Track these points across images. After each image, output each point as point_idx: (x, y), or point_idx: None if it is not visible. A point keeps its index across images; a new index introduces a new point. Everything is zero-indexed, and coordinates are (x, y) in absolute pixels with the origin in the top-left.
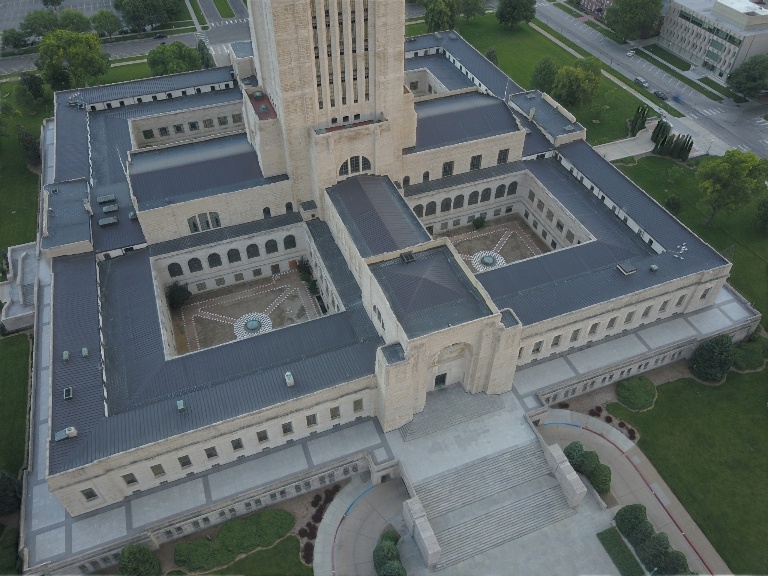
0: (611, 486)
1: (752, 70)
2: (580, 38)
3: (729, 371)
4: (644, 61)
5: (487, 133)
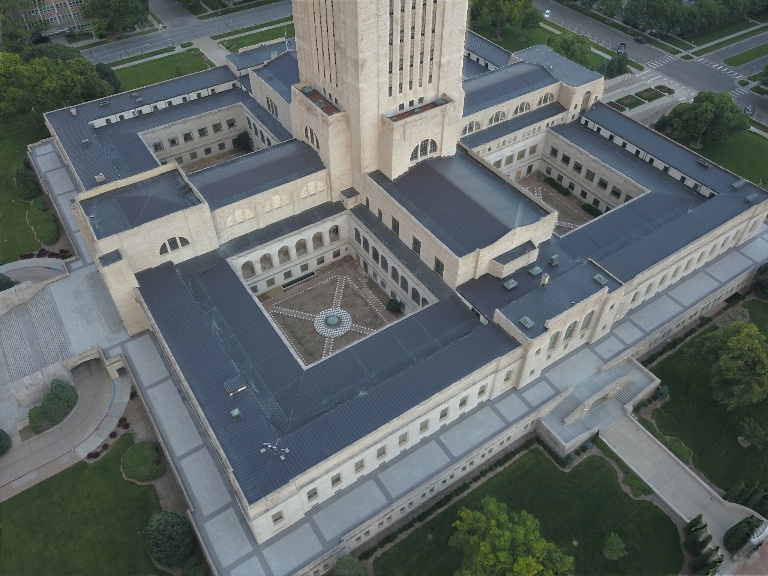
0: (42, 436)
1: None
2: None
3: (173, 575)
4: None
5: (446, 231)
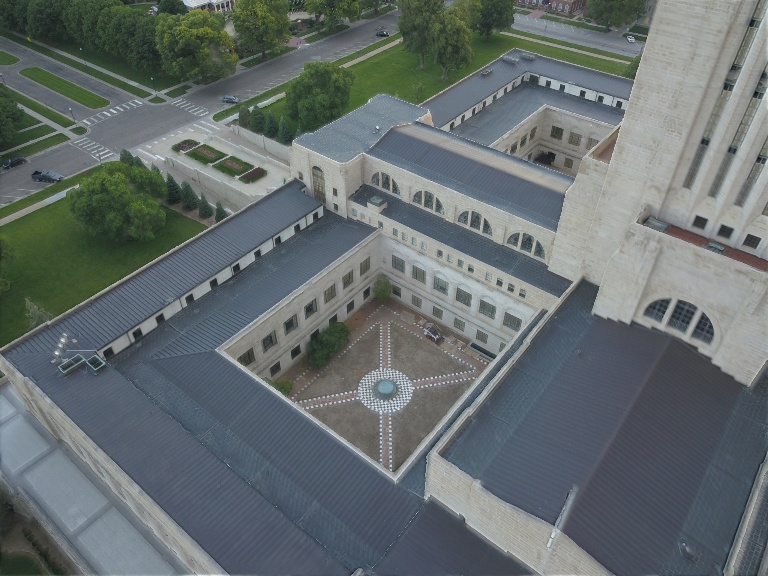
0: None
1: None
2: (562, 35)
3: None
4: None
5: None
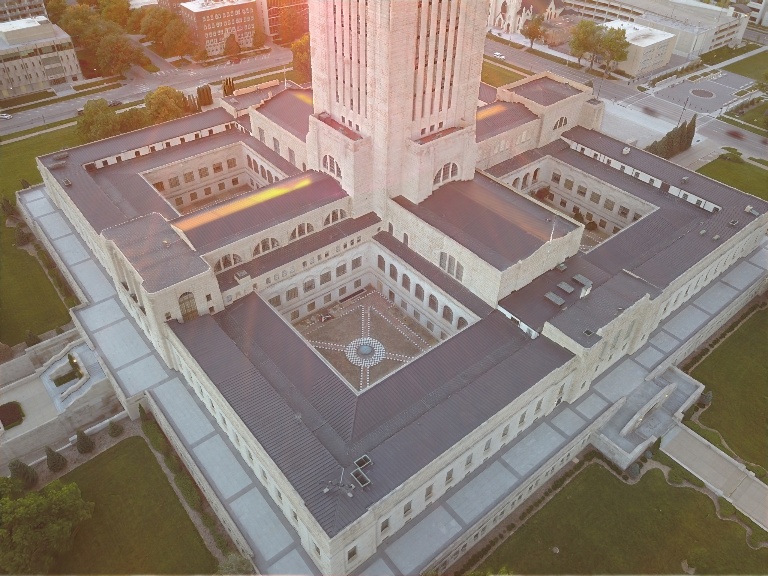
0: None
1: (120, 48)
2: None
3: None
4: (25, 112)
5: None
